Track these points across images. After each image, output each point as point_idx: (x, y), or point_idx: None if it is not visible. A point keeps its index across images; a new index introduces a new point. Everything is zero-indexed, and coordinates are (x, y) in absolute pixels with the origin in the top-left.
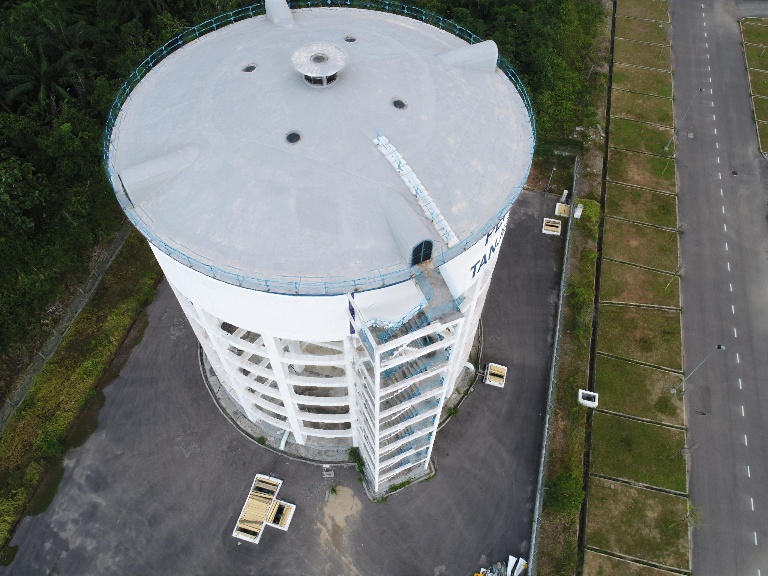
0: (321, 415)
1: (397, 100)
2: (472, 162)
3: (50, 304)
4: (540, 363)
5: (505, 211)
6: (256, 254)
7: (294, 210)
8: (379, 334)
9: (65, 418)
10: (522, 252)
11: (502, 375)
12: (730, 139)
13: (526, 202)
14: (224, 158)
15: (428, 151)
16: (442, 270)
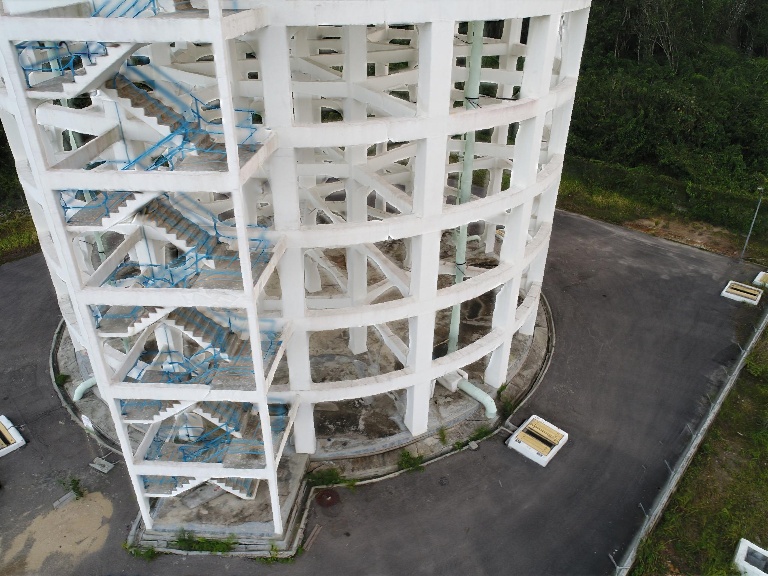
0: (108, 285)
1: None
2: None
3: (26, 206)
4: (651, 457)
5: None
6: None
7: None
8: None
9: None
10: (672, 306)
11: (551, 442)
12: None
13: (701, 261)
14: None
15: None
16: None
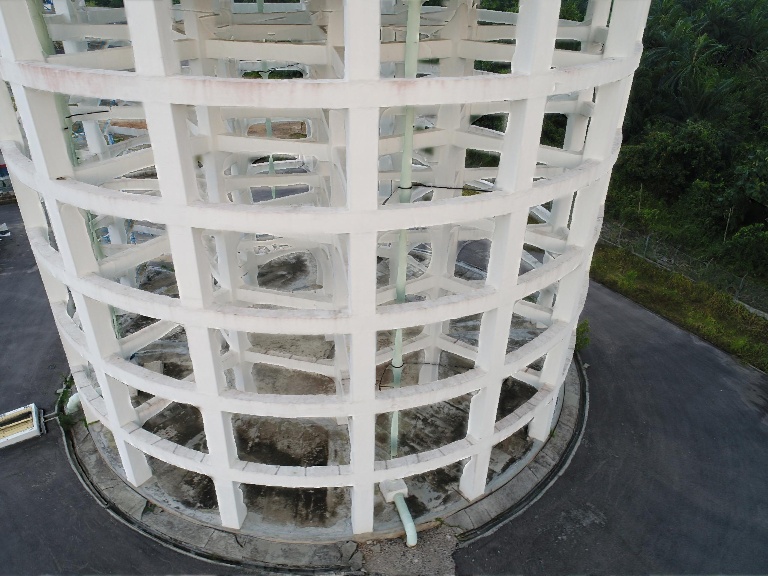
0: None
1: None
2: None
3: None
4: None
5: None
6: None
7: None
8: None
9: None
10: None
11: (3, 427)
12: None
13: None
14: None
15: None
16: None
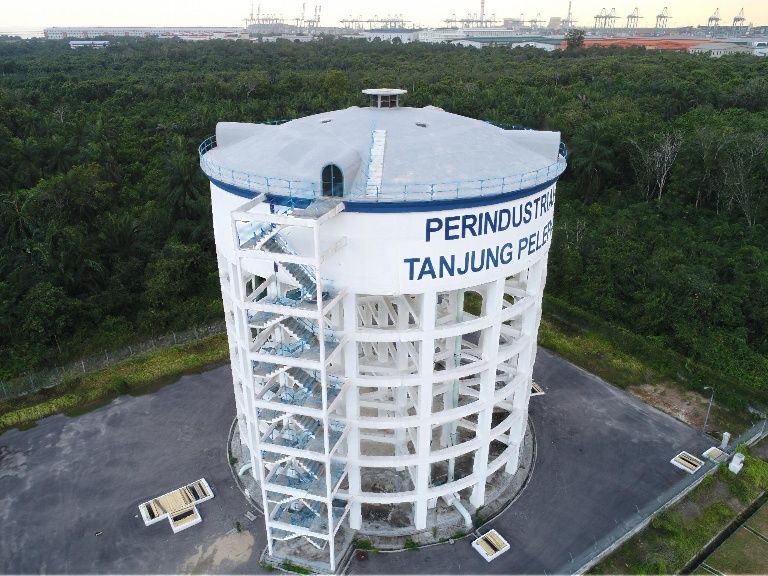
0: None
1: (423, 124)
2: (446, 165)
3: None
4: (558, 569)
5: (444, 198)
6: (238, 165)
7: (282, 148)
8: (269, 242)
9: (145, 375)
10: (627, 465)
11: (497, 548)
12: None
13: (671, 430)
14: (280, 127)
15: (411, 146)
16: (360, 226)
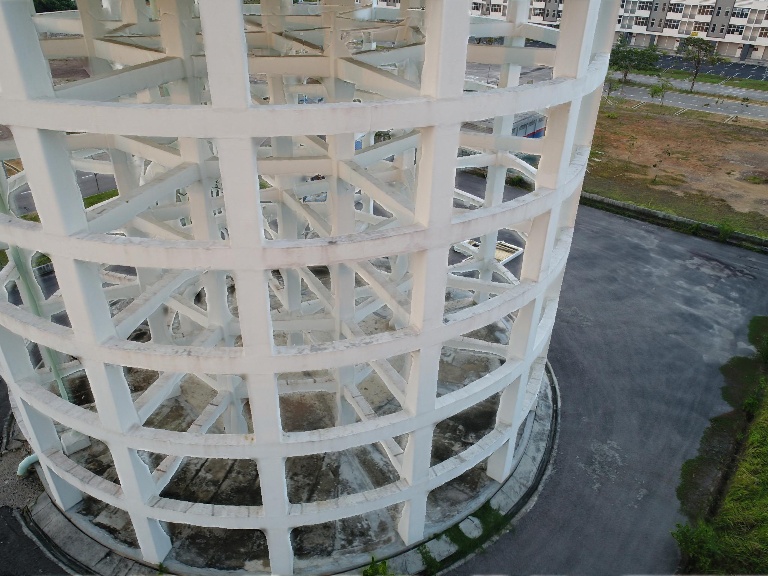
0: None
1: None
2: None
3: None
4: None
5: None
6: None
7: None
8: None
9: None
10: None
11: None
12: None
13: None
14: None
15: None
16: None
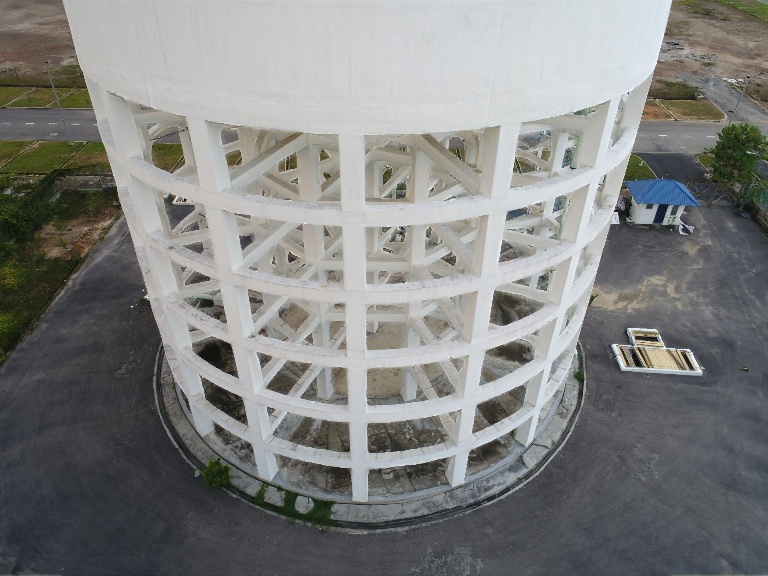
0: None
1: None
2: None
3: None
4: None
5: None
6: None
7: None
8: None
9: None
10: None
11: None
12: (68, 119)
13: None
14: None
15: None
16: None
